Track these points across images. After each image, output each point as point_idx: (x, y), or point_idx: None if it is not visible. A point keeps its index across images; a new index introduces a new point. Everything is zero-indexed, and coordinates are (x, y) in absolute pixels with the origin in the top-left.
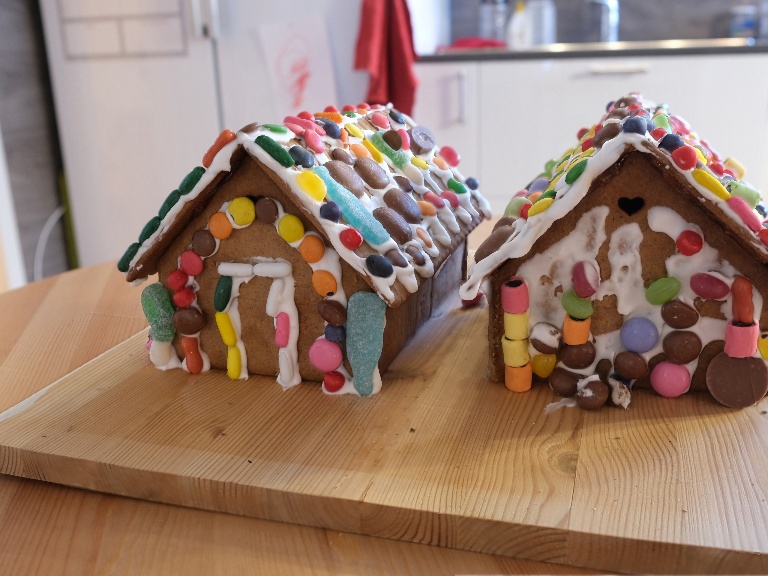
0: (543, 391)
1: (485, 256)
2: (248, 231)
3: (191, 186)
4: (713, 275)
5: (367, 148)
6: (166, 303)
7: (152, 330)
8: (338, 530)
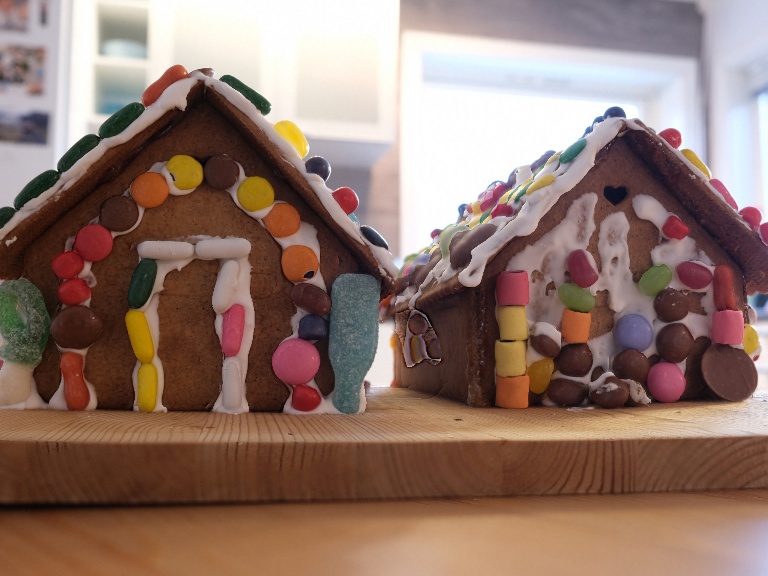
0: (543, 407)
1: (476, 246)
2: (188, 200)
3: (123, 124)
4: (697, 263)
5: None
6: (40, 302)
7: (8, 345)
8: (469, 495)
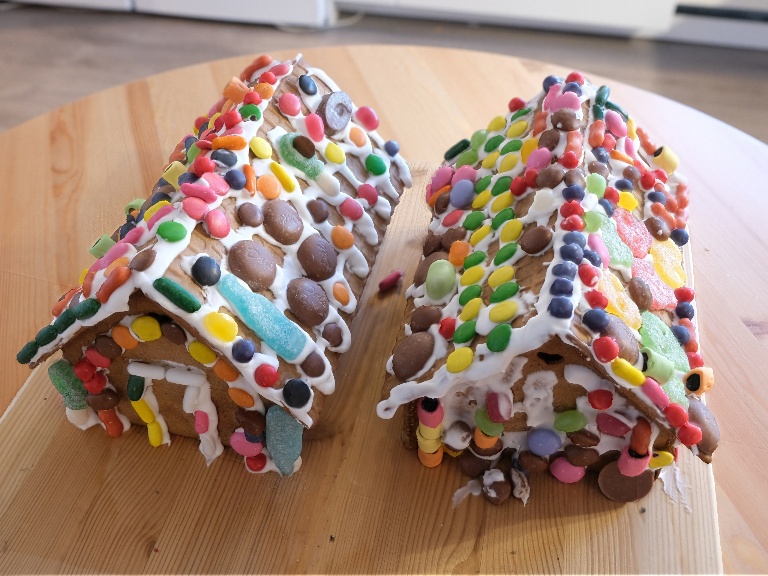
0: (452, 466)
1: (403, 376)
2: (155, 342)
3: (87, 317)
4: (618, 418)
5: (276, 176)
6: (76, 383)
7: (65, 401)
8: None
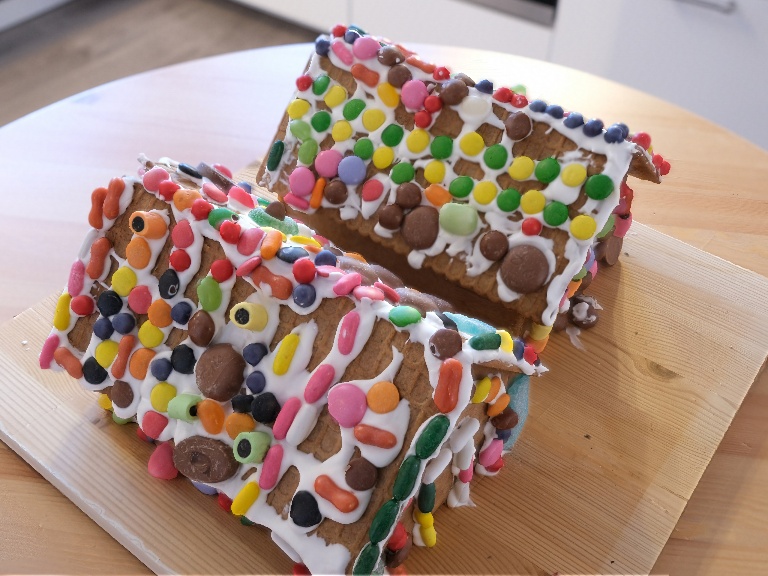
0: None
1: None
2: None
3: None
4: None
5: (308, 245)
6: (380, 561)
7: None
8: None
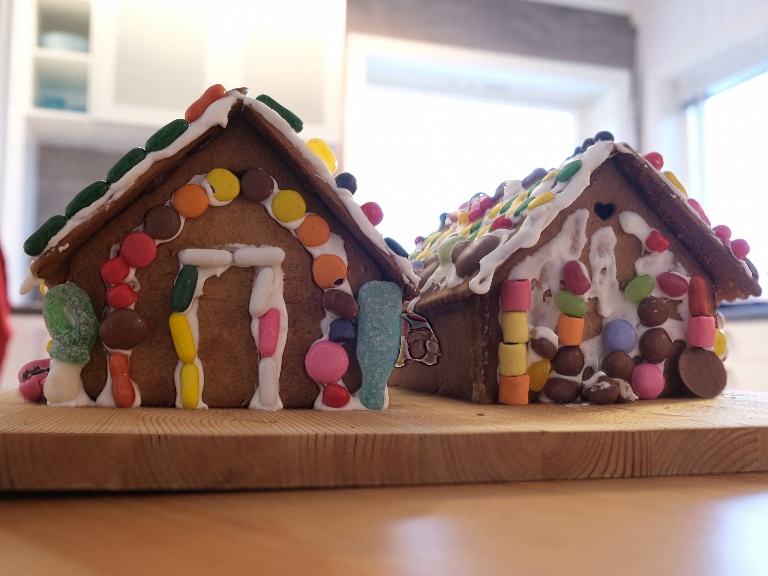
0: None
1: (483, 256)
2: (225, 211)
3: (170, 139)
4: (675, 273)
5: None
6: (89, 306)
7: (59, 346)
8: (514, 480)
